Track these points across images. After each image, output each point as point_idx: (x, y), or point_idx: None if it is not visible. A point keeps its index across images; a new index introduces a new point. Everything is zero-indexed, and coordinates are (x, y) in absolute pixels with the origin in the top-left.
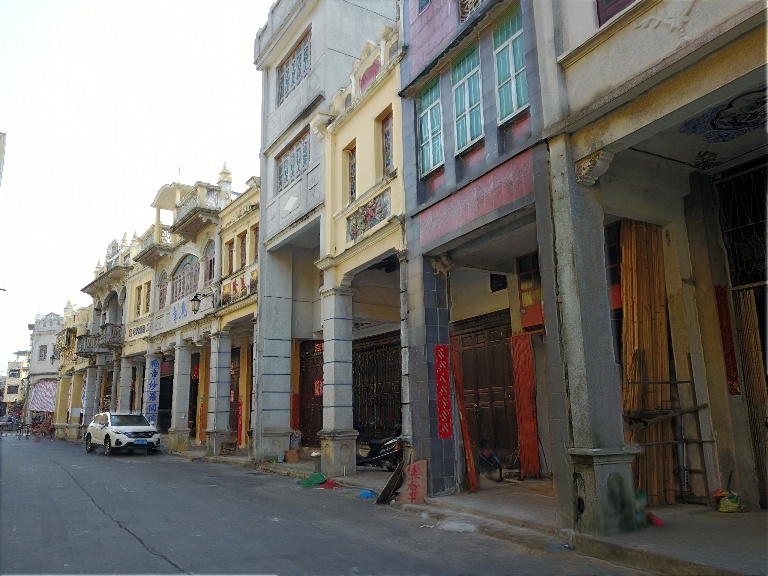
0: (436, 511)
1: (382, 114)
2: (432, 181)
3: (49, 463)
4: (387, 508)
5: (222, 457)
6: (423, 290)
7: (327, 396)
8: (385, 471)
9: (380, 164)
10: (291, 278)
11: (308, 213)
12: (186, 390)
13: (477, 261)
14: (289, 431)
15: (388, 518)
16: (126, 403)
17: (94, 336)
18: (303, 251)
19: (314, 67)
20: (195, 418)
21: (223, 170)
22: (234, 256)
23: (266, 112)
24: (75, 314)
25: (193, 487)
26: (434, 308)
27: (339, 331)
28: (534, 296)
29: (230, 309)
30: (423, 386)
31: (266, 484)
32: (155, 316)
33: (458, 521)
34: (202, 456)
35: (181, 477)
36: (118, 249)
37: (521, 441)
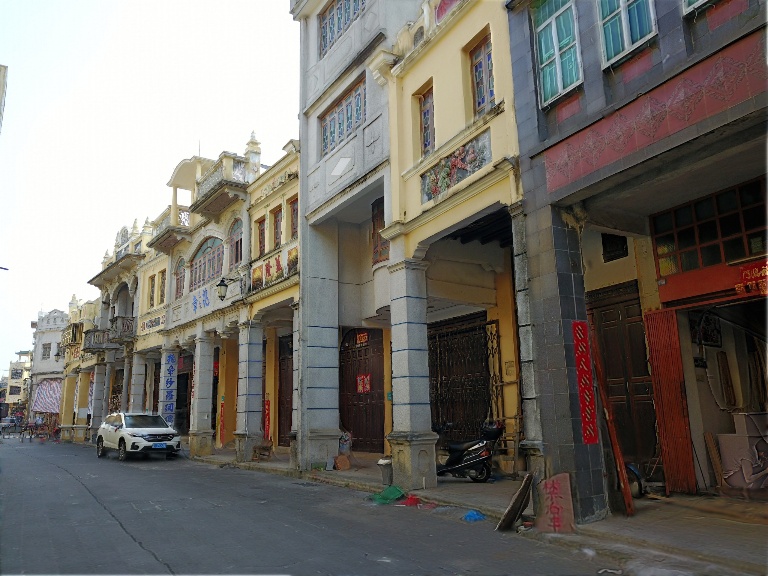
0: (600, 545)
1: (472, 41)
2: (558, 110)
3: (58, 471)
4: (519, 538)
5: (255, 463)
6: (554, 250)
7: (399, 391)
8: (469, 482)
9: (469, 103)
10: (337, 256)
11: (367, 174)
12: (209, 387)
13: (606, 218)
14: (338, 433)
15: (534, 555)
16: (139, 403)
17: (102, 331)
18: (349, 226)
19: (370, 4)
20: (213, 419)
21: (251, 140)
22: (266, 234)
23: (305, 67)
24: (81, 309)
25: (240, 504)
26: (568, 273)
27: (412, 312)
28: (679, 262)
29: (263, 294)
30: (559, 375)
31: (328, 499)
32: (171, 307)
33: (653, 564)
34: (231, 462)
35: (218, 489)
36: (128, 237)
37: (664, 446)
